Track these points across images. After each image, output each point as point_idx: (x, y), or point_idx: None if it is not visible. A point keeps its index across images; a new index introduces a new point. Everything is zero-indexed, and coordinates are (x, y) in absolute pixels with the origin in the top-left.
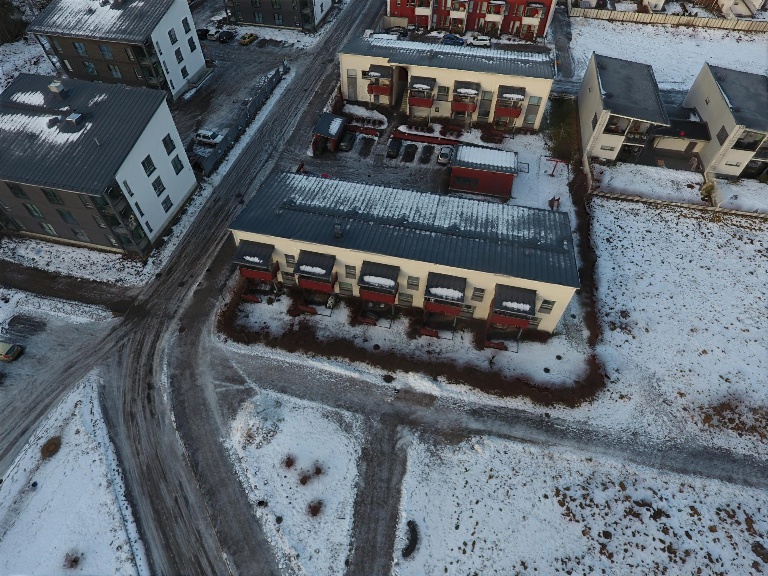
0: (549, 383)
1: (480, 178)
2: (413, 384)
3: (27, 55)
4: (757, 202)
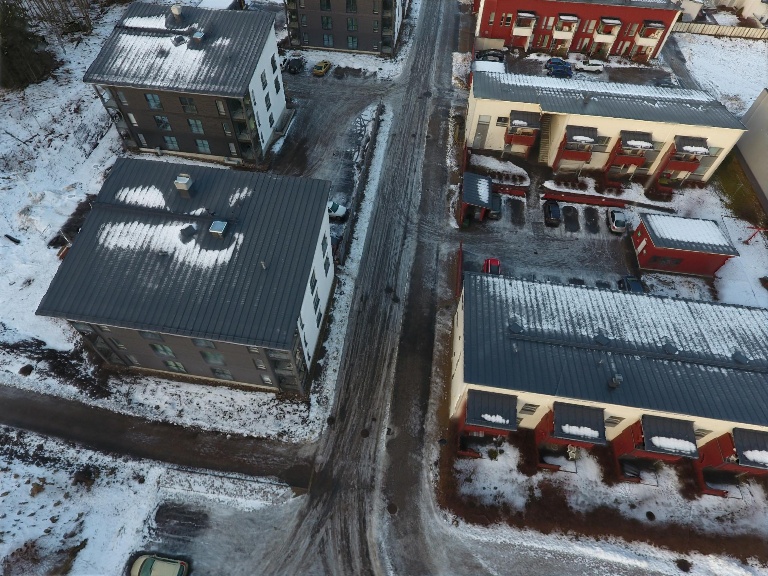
0: None
1: (686, 258)
2: (719, 572)
3: (62, 99)
4: None
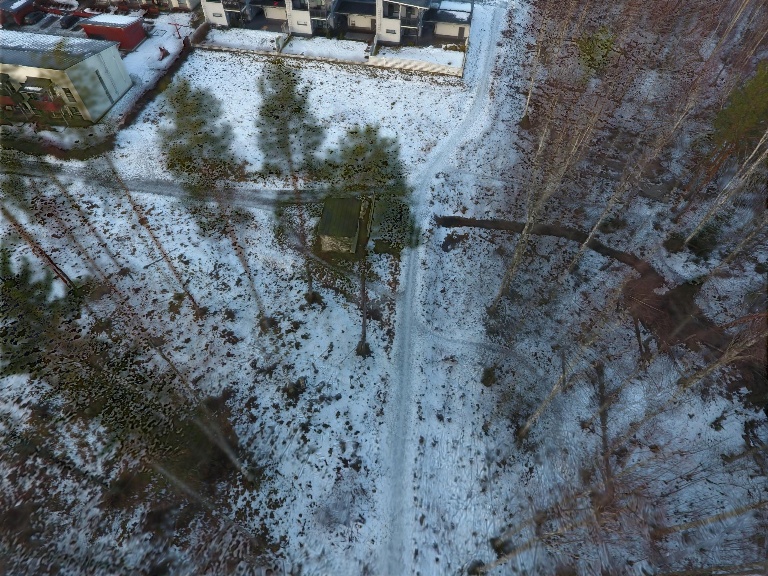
0: (72, 147)
1: (104, 34)
2: None
3: None
4: (311, 49)
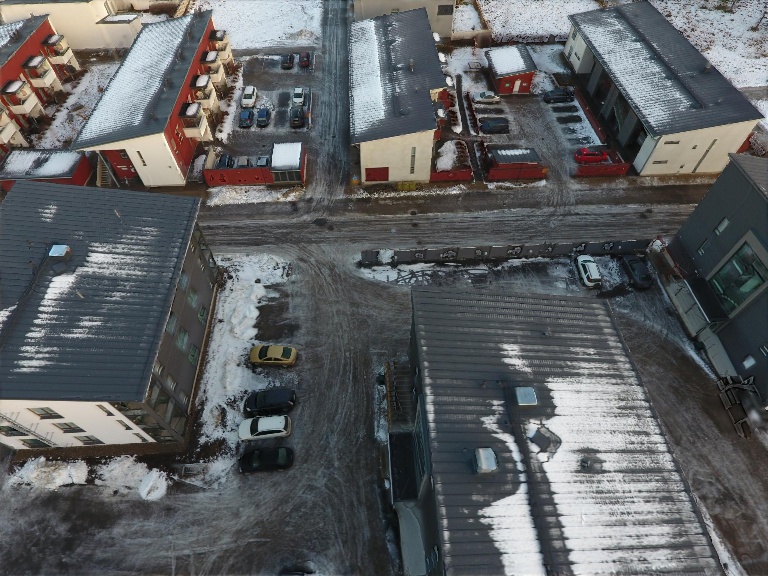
0: None
1: None
2: None
3: None
4: None
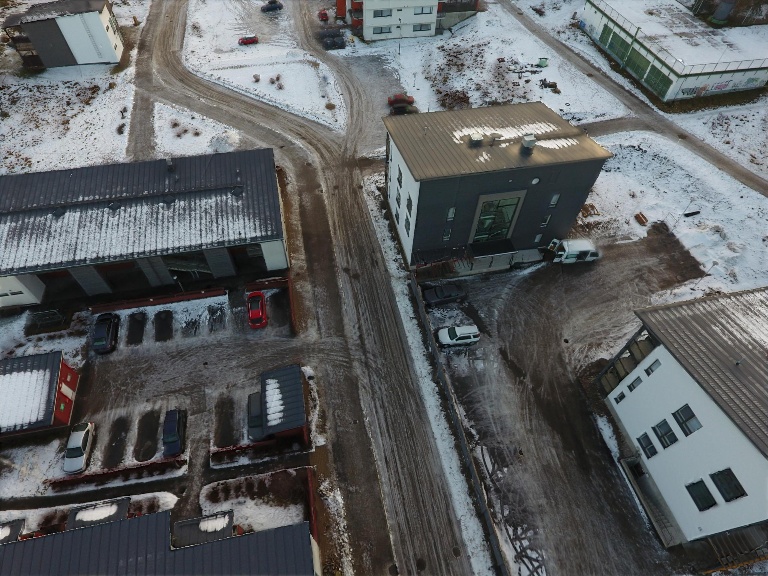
0: None
1: None
2: None
3: None
4: None
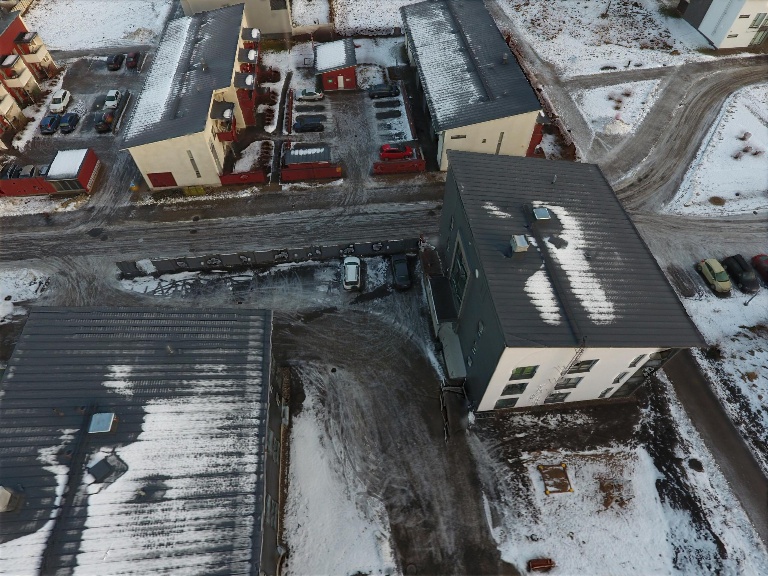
0: None
1: None
2: (535, 81)
3: None
4: None
